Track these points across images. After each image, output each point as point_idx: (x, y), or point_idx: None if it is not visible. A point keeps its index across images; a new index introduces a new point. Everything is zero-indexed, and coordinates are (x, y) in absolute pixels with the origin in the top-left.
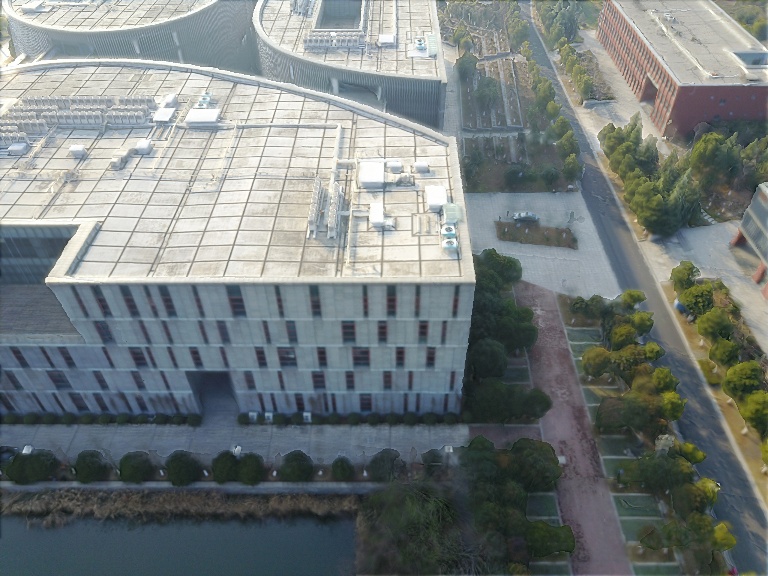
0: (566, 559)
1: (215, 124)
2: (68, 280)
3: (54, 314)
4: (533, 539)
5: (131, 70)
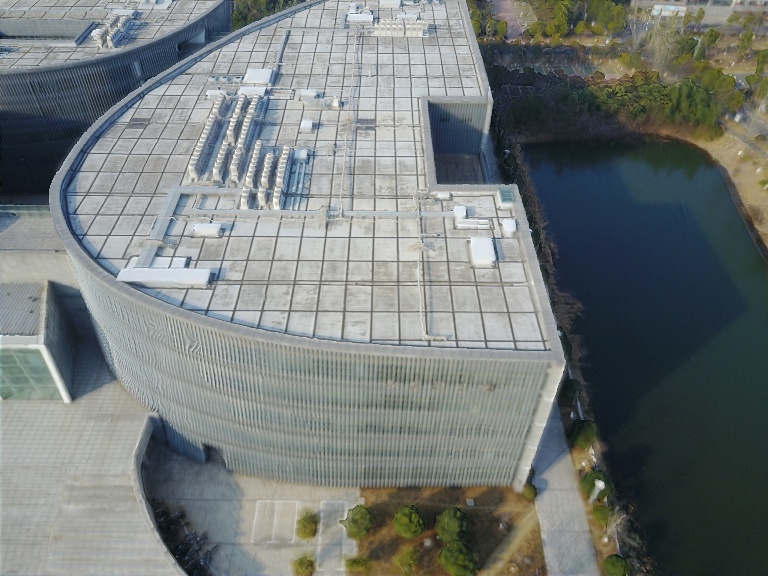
0: (526, 86)
1: (274, 71)
2: (490, 93)
3: (457, 174)
4: (534, 73)
5: (112, 132)
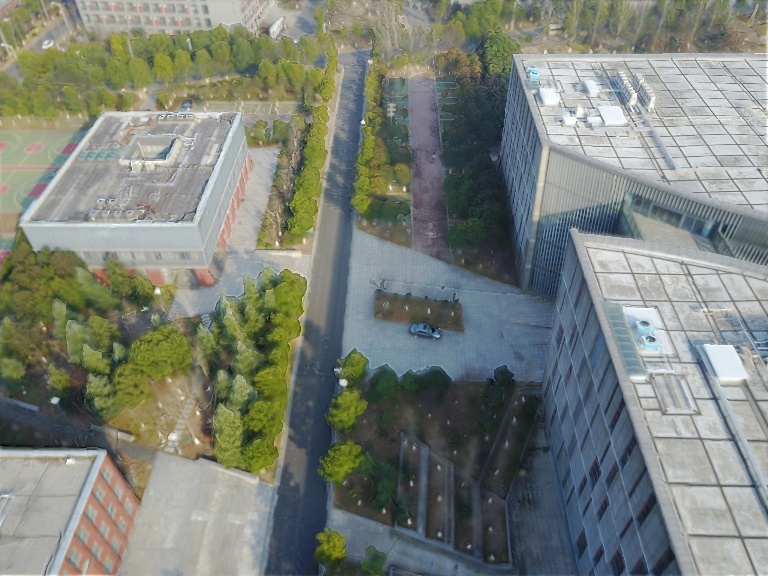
0: None
1: None
2: None
3: None
4: None
5: None
